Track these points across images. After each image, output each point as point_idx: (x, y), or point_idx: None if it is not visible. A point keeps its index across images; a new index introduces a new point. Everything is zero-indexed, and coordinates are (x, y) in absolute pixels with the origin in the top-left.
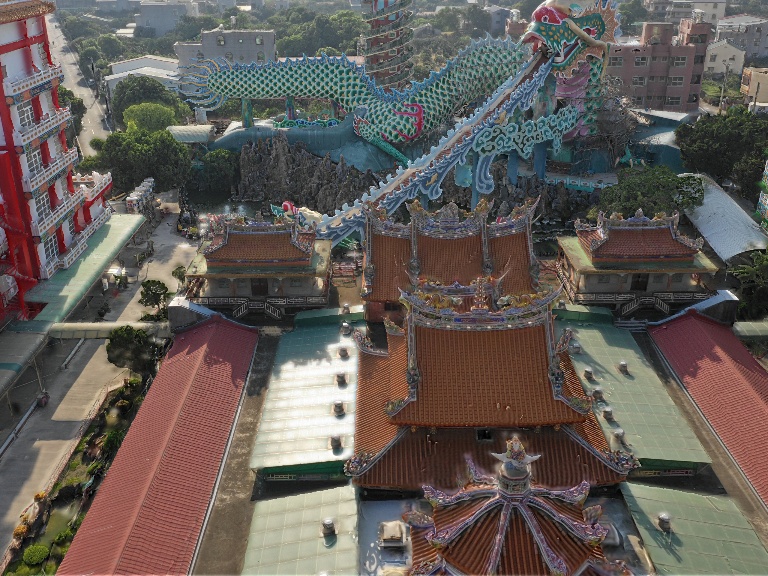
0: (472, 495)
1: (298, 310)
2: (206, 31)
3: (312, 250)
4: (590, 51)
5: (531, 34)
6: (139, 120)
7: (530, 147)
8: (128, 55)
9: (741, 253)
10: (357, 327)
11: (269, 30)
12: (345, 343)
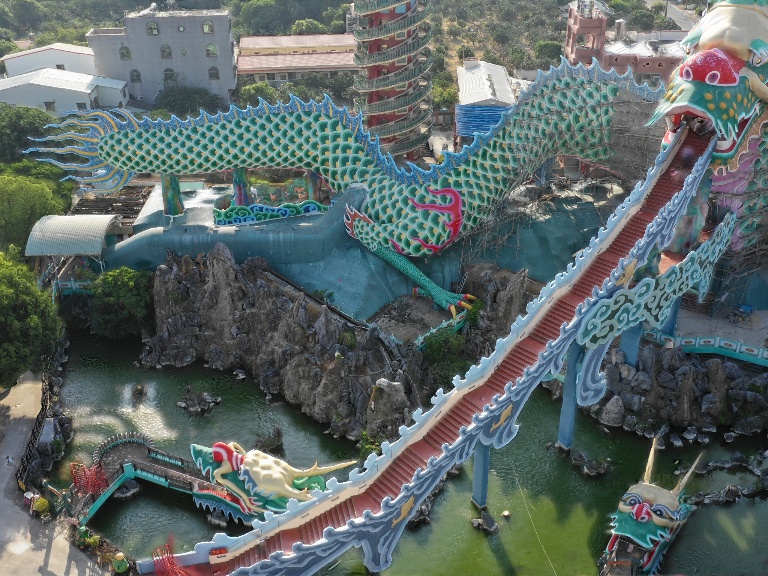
0: None
1: None
2: (132, 14)
3: None
4: (767, 116)
5: (686, 108)
6: None
7: (668, 308)
8: (47, 27)
9: None
10: None
11: (222, 12)
12: None
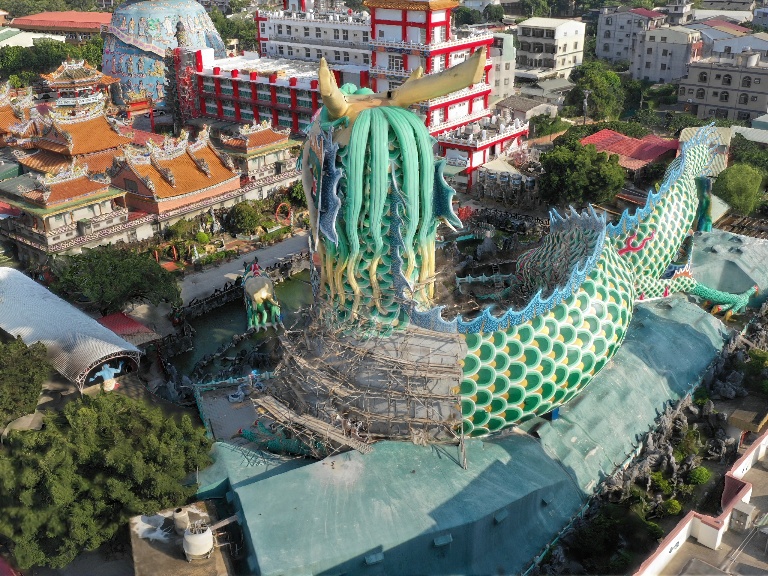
0: (48, 121)
1: None
2: None
3: None
4: None
5: None
6: None
7: None
8: None
9: None
10: None
11: None
12: None
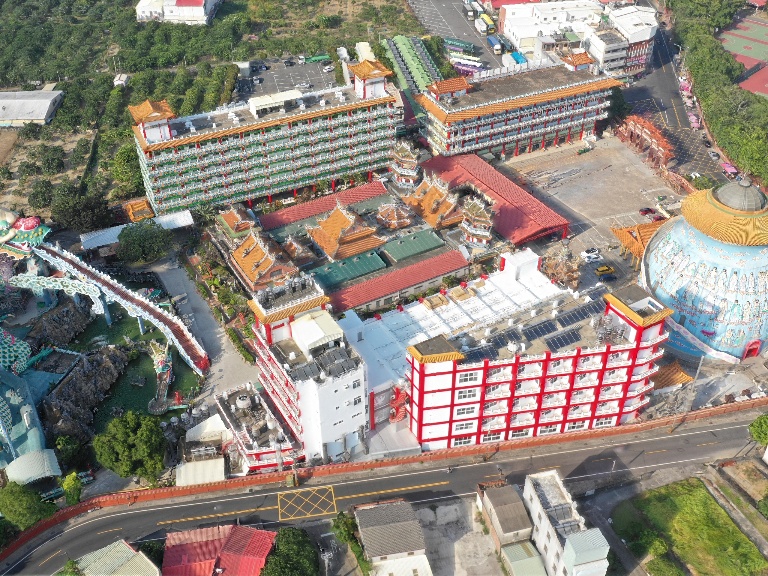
0: None
1: None
2: None
3: None
4: None
5: None
6: None
7: None
8: None
9: (193, 217)
10: (310, 272)
11: None
12: (322, 271)
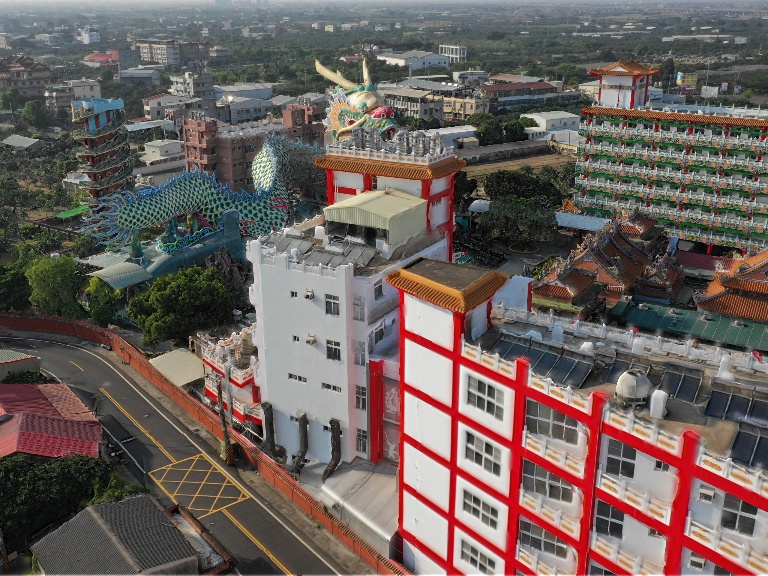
0: None
1: (602, 313)
2: None
3: None
4: None
5: (392, 127)
6: (62, 278)
7: None
8: None
9: None
10: None
11: None
12: (661, 310)
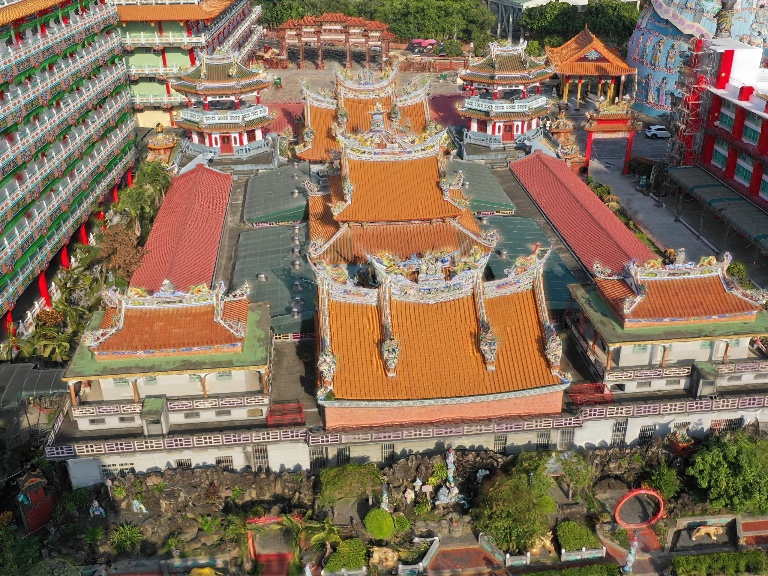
0: None
1: None
2: None
3: (603, 289)
4: None
5: None
6: None
7: None
8: None
9: None
10: None
11: None
12: None
